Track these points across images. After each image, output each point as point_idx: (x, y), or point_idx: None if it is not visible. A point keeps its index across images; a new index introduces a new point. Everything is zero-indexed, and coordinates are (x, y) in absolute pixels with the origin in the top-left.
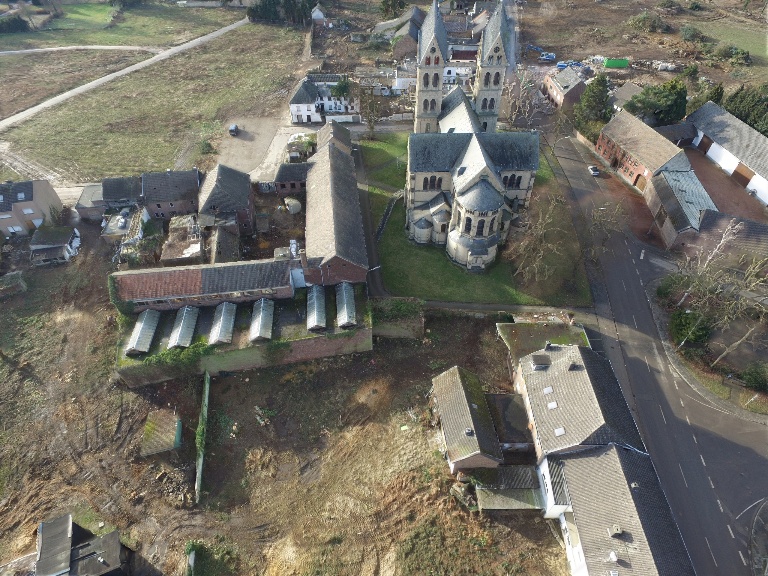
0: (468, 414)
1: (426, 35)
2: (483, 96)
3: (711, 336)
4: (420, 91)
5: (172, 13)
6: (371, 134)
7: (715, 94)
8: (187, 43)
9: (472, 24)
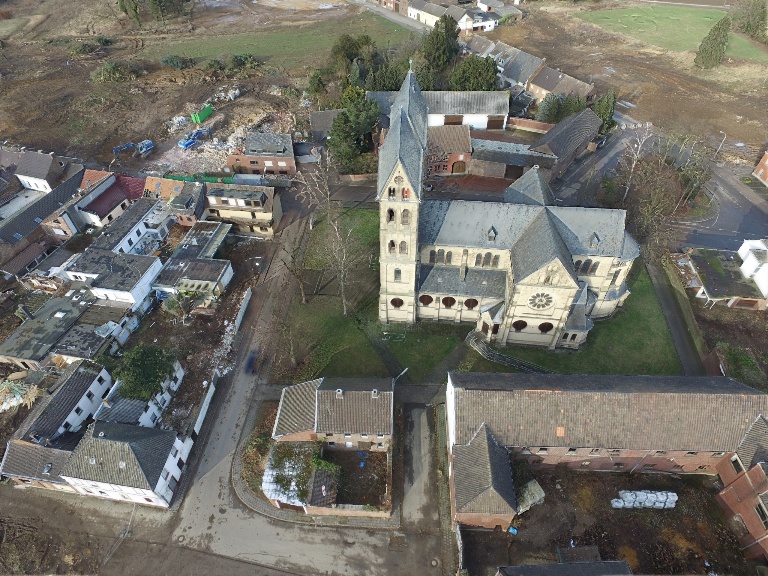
0: None
1: (411, 158)
2: None
3: (645, 198)
4: (416, 230)
5: None
6: (294, 360)
7: None
8: None
9: (4, 171)
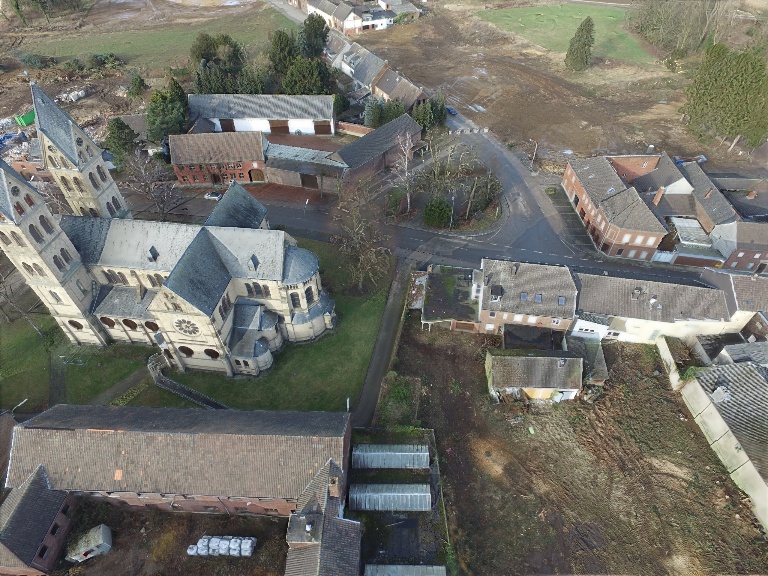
0: (545, 359)
1: None
2: (103, 202)
3: None
4: (40, 253)
5: None
6: None
7: (177, 89)
8: None
9: None
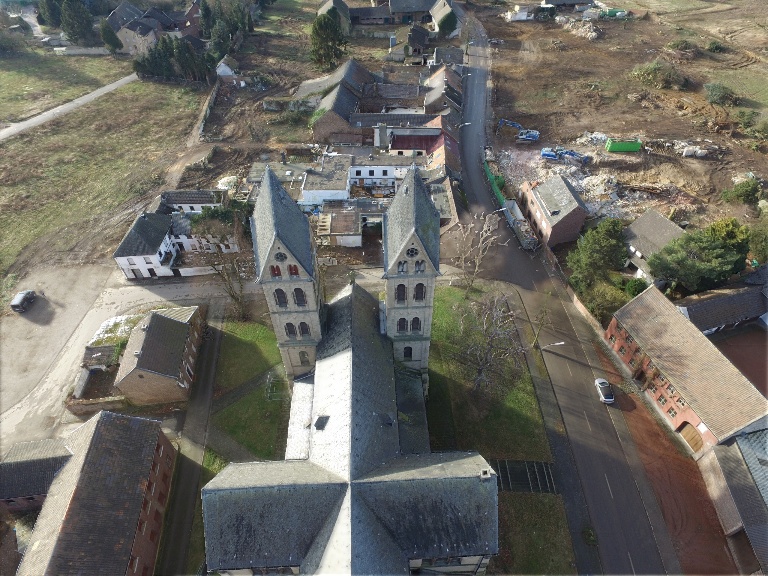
0: None
1: (262, 230)
2: (398, 315)
3: None
4: (273, 313)
5: (42, 65)
6: (241, 310)
7: None
8: (38, 116)
9: (425, 88)
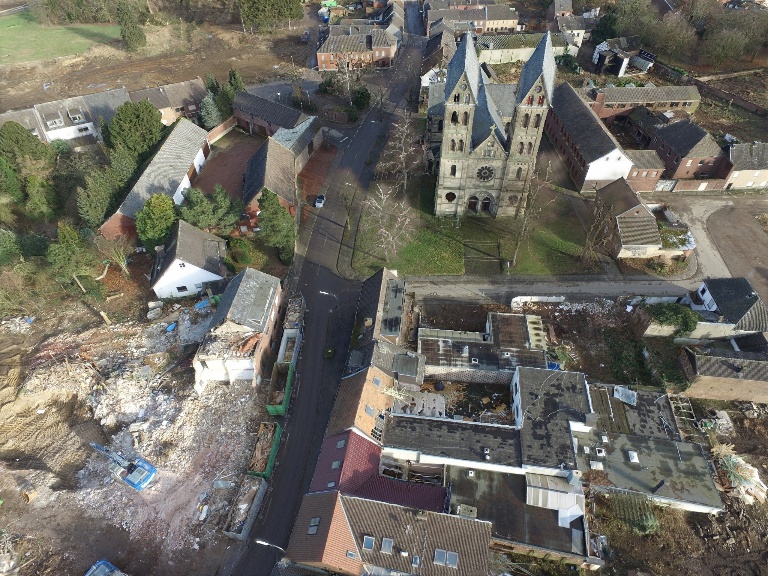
0: None
1: None
2: None
3: None
4: None
5: None
6: None
7: None
8: None
9: None
